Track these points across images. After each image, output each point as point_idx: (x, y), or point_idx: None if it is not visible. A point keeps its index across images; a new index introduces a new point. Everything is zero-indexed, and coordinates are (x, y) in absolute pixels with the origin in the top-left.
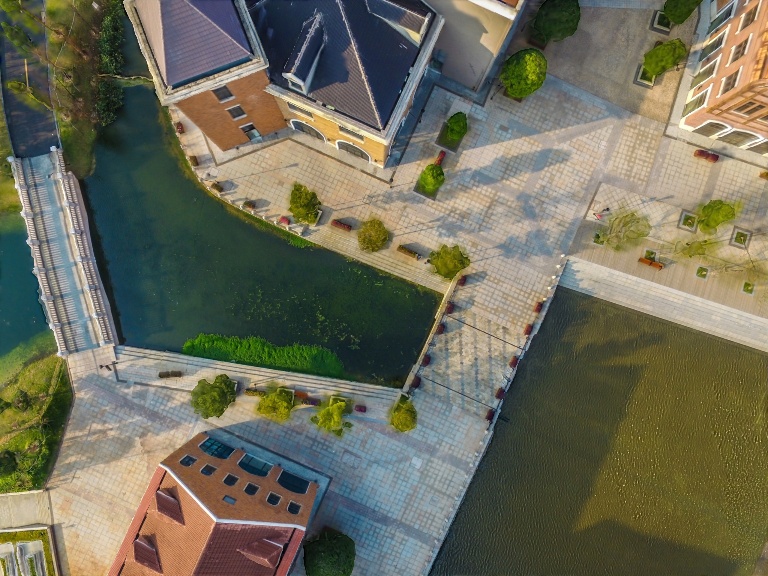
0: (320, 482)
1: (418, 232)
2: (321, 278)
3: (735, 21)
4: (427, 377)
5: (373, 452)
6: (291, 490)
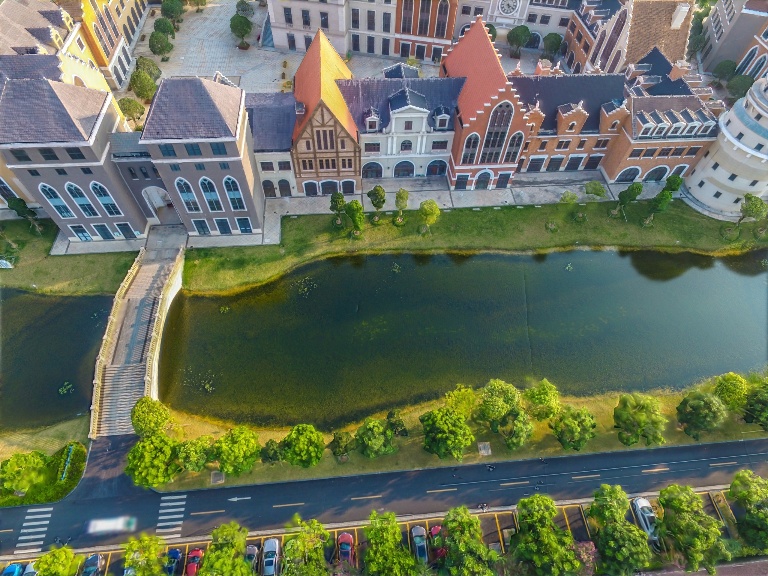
0: None
1: None
2: (713, 4)
3: None
4: None
5: None
6: None
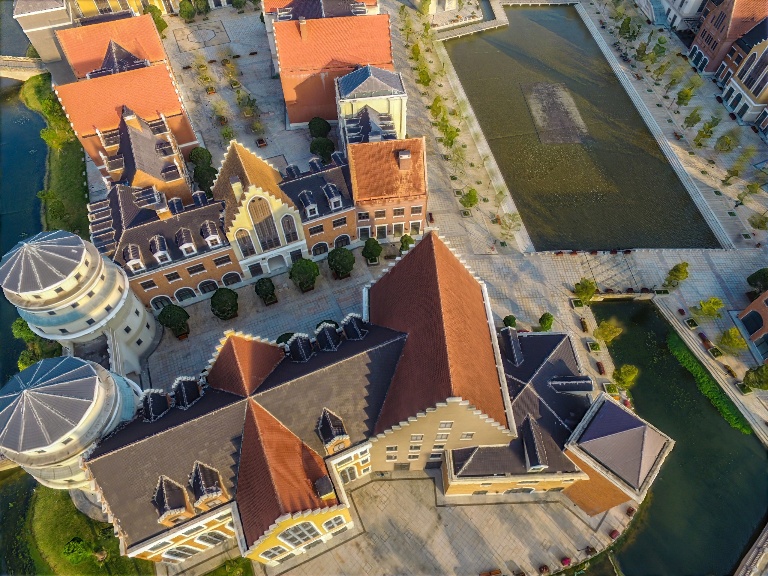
0: (735, 315)
1: (569, 326)
2: None
3: (375, 223)
4: (637, 287)
5: (695, 296)
6: (760, 316)
